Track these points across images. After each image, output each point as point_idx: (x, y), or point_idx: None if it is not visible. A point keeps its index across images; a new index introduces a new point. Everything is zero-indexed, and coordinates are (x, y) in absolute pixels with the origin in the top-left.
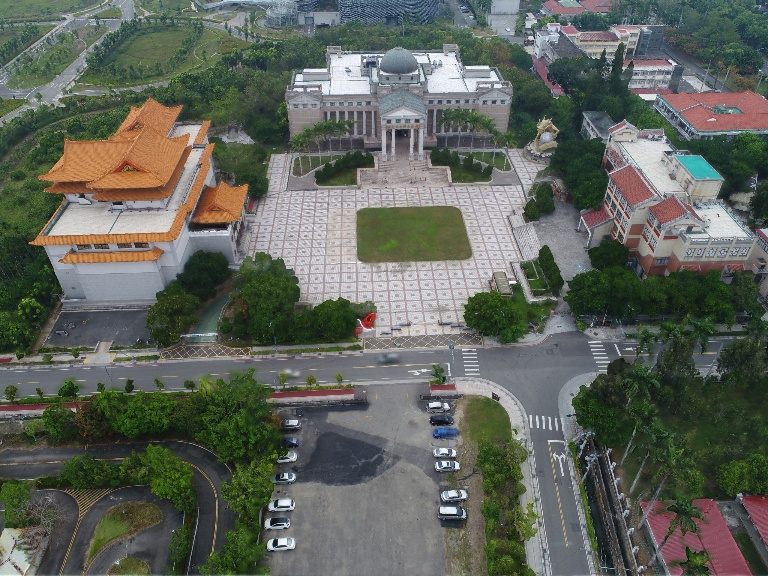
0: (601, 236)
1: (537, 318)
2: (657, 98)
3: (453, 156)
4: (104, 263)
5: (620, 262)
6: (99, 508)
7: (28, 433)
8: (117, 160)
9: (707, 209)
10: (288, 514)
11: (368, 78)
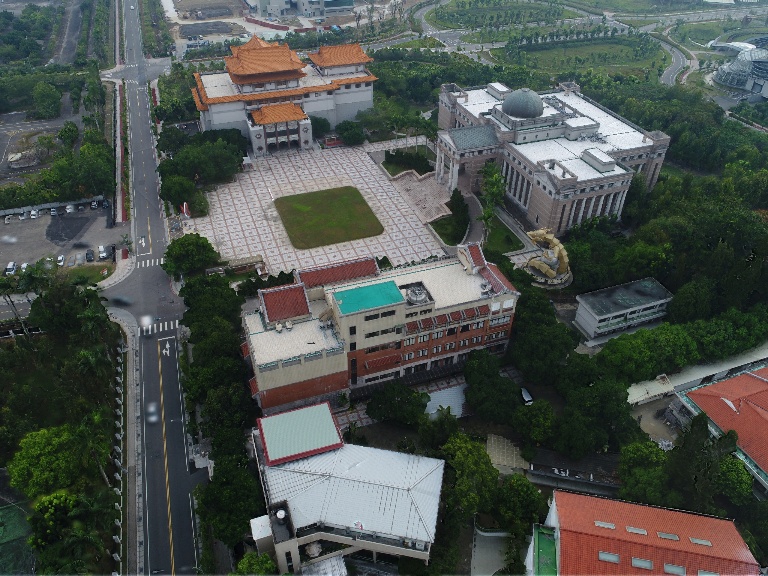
0: None
1: None
2: None
3: None
4: None
5: None
6: None
7: None
8: None
9: (323, 335)
10: (30, 218)
11: None
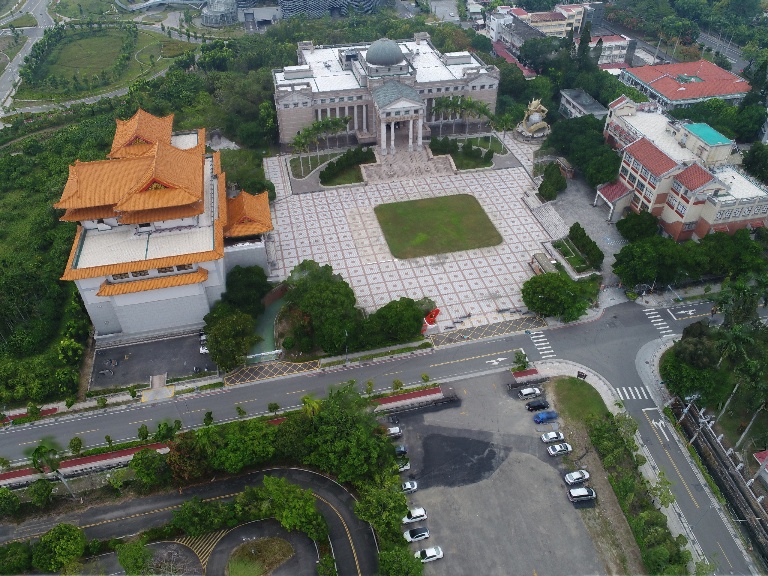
0: (622, 208)
1: (588, 294)
2: (622, 72)
3: (452, 144)
4: (146, 291)
5: (653, 231)
6: (220, 552)
7: (115, 486)
8: (138, 179)
9: (721, 173)
10: (423, 523)
11: (351, 72)
